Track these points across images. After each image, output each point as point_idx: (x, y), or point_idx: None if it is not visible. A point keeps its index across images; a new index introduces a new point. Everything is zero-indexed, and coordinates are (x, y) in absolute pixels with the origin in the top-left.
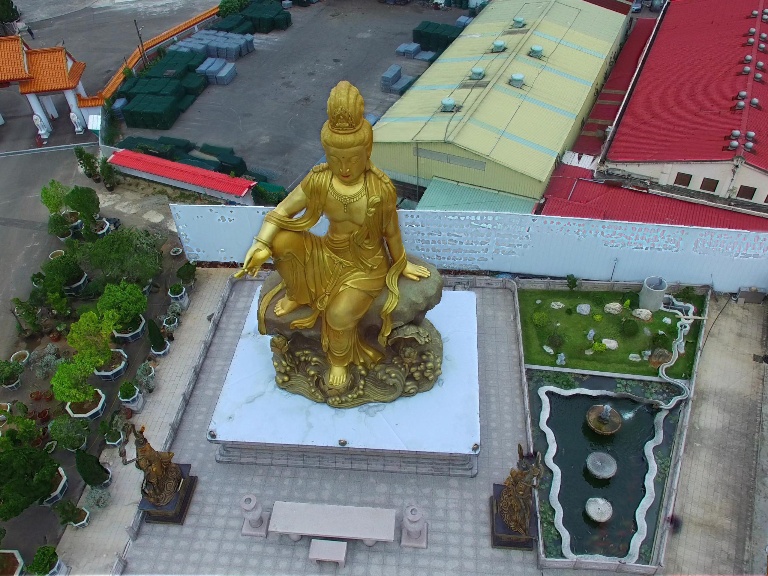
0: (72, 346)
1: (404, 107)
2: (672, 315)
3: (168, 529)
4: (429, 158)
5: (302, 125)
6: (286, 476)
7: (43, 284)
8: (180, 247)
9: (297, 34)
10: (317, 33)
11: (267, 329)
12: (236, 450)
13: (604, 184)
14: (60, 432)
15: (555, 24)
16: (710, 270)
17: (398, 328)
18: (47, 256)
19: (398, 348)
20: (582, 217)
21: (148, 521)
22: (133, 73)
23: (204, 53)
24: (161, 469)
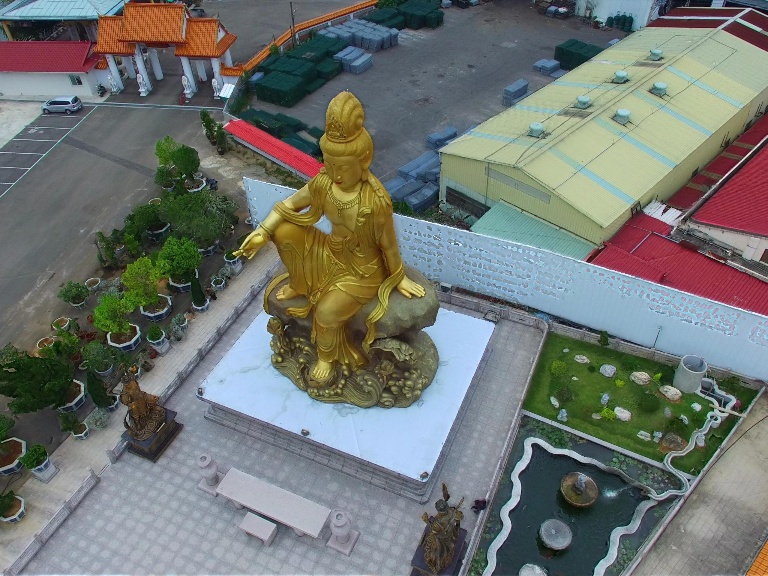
0: (125, 283)
1: (496, 124)
2: (706, 402)
3: (142, 463)
4: (498, 180)
5: (411, 124)
6: (255, 448)
7: (125, 225)
8: None
9: (444, 34)
10: (464, 36)
11: (270, 309)
12: (222, 412)
13: (679, 244)
14: (89, 354)
15: (697, 62)
16: (767, 365)
17: (381, 339)
18: (149, 201)
19: (381, 358)
20: (635, 274)
21: (130, 450)
22: (280, 50)
23: (349, 41)
24: (145, 409)
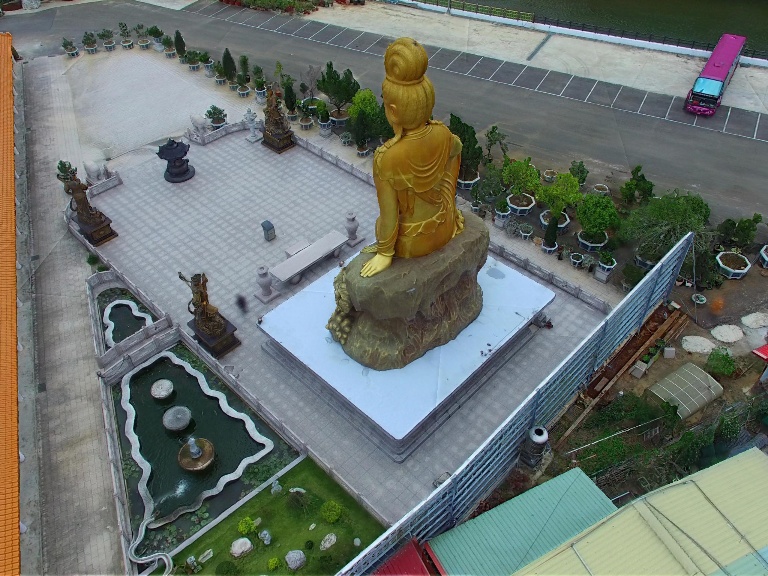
0: None
1: None
2: None
3: None
4: None
5: None
6: None
7: None
8: (711, 307)
9: None
10: None
11: None
12: None
13: None
14: None
15: None
16: None
17: None
18: None
19: None
20: None
21: None
22: None
23: None
24: None
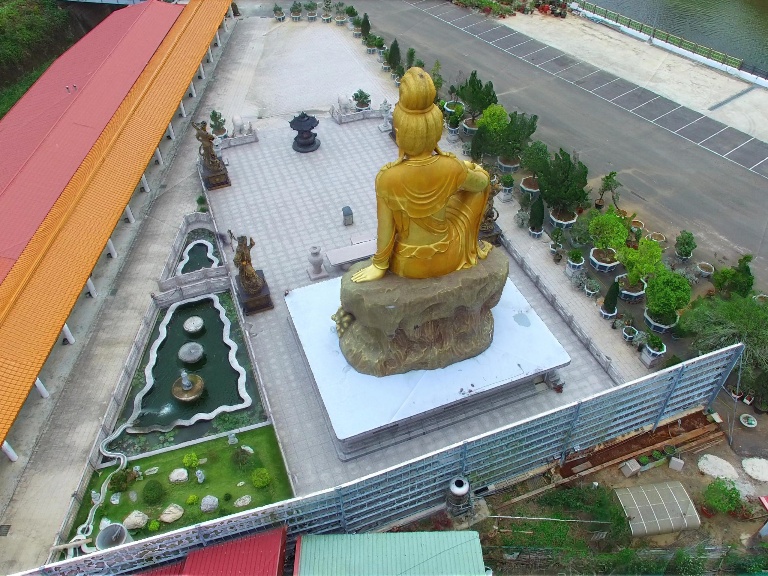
0: None
1: None
2: None
3: None
4: None
5: None
6: None
7: None
8: (760, 435)
9: None
10: None
11: None
12: None
13: None
14: None
15: None
16: None
17: None
18: None
19: None
20: None
21: None
22: None
23: None
24: None
